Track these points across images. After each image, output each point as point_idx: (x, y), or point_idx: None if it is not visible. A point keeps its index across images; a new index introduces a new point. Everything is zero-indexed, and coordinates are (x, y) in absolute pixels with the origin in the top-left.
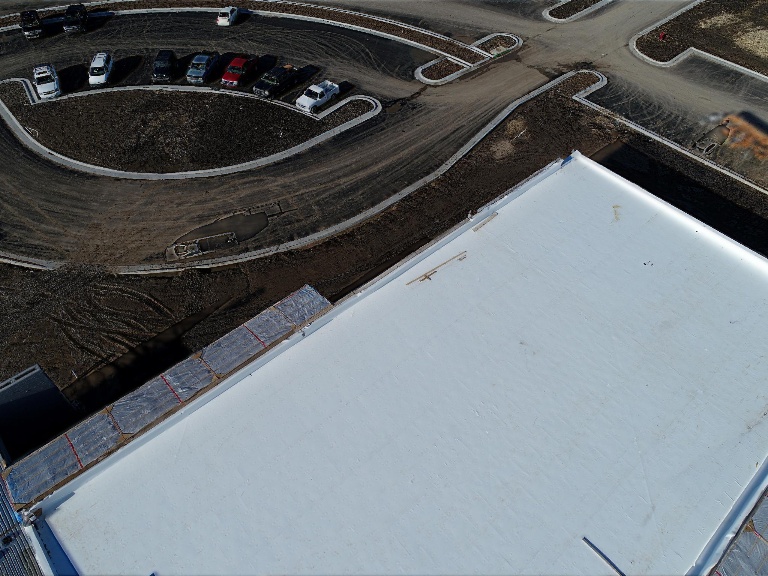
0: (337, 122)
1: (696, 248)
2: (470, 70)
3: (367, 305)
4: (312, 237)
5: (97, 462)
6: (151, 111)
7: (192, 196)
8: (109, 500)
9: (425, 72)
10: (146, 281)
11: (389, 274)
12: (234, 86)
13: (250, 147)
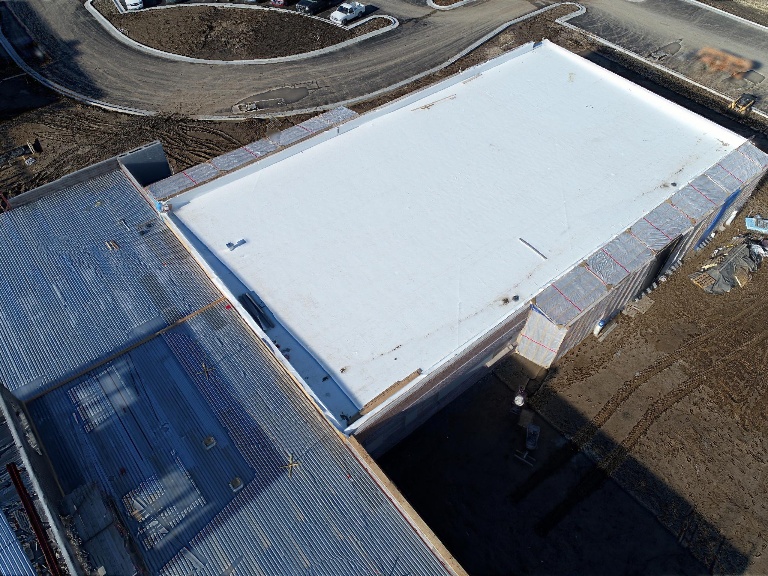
0: (363, 32)
1: (627, 99)
2: (473, 0)
3: (383, 120)
4: (342, 103)
5: (205, 183)
6: (215, 20)
7: (250, 75)
8: (213, 206)
9: (436, 0)
10: (219, 124)
11: (399, 101)
12: (281, 4)
13: (294, 46)
